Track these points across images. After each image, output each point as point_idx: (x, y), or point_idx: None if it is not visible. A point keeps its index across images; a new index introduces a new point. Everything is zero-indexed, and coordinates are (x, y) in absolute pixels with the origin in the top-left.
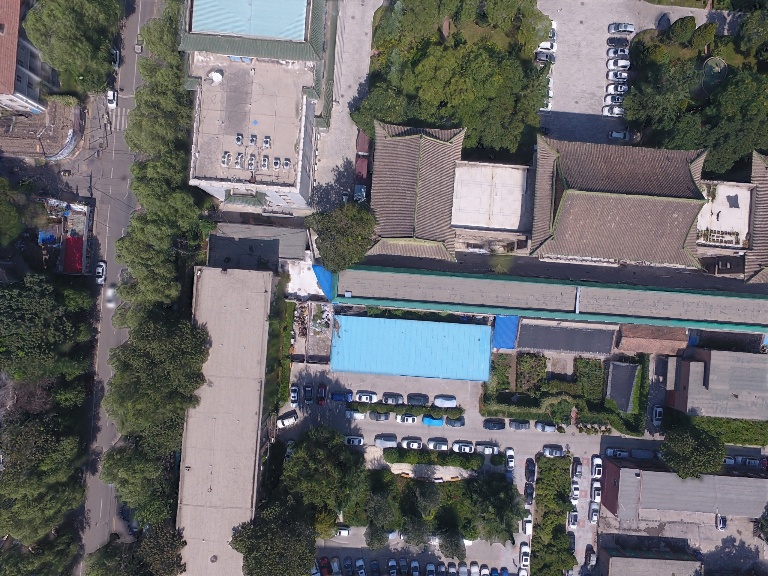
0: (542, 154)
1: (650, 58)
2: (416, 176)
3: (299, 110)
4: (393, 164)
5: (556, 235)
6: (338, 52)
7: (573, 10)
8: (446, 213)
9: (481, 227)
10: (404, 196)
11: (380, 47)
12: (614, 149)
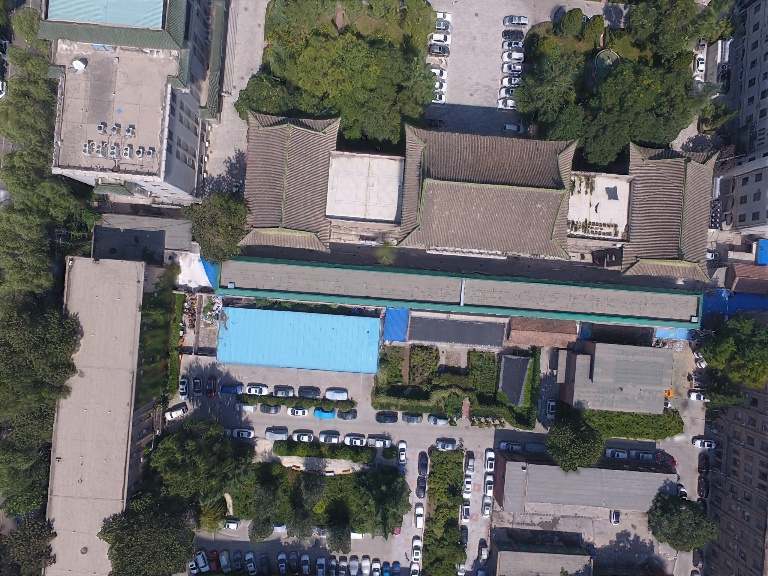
0: (410, 144)
1: (539, 50)
2: (284, 166)
3: (164, 99)
4: (265, 154)
5: (423, 225)
6: (230, 43)
7: (468, 2)
8: (320, 203)
9: (357, 218)
10: (274, 186)
11: (269, 38)
12: (483, 139)
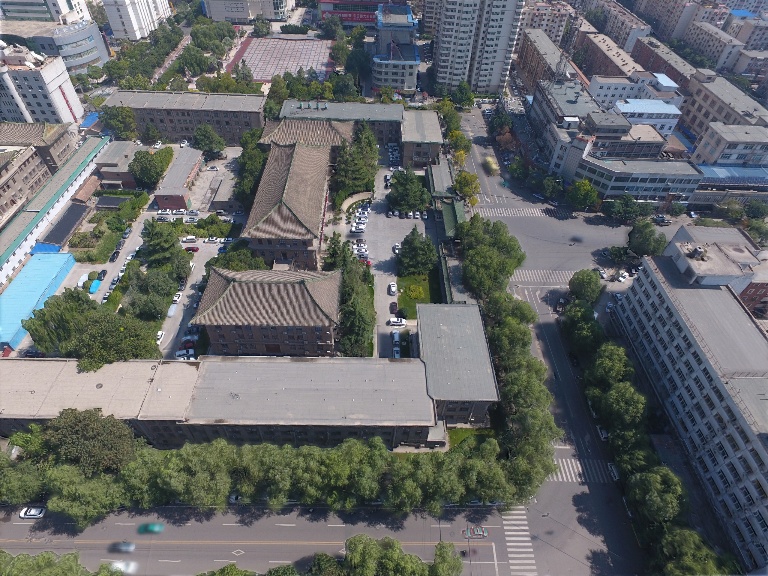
0: None
1: None
2: None
3: None
4: None
5: None
6: None
7: None
8: None
9: None
10: None
11: None
12: None
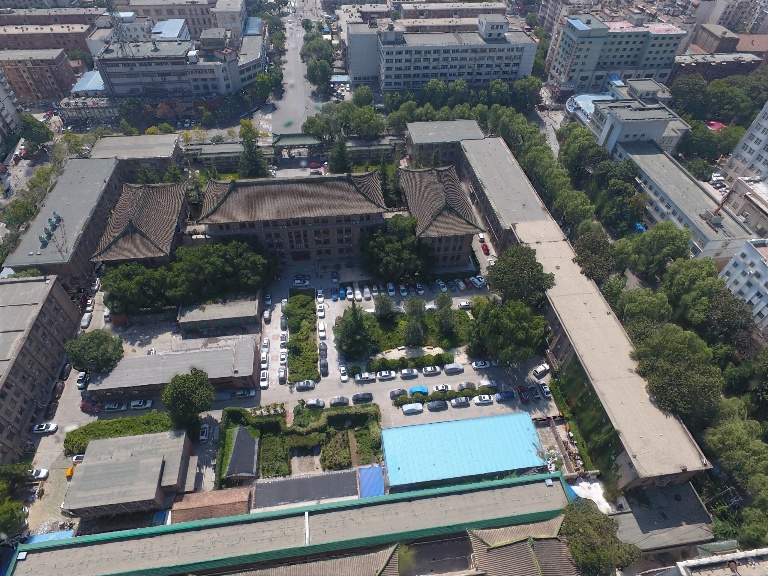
0: None
1: None
2: None
3: None
4: None
5: None
6: None
7: None
8: None
9: None
10: None
11: None
12: None
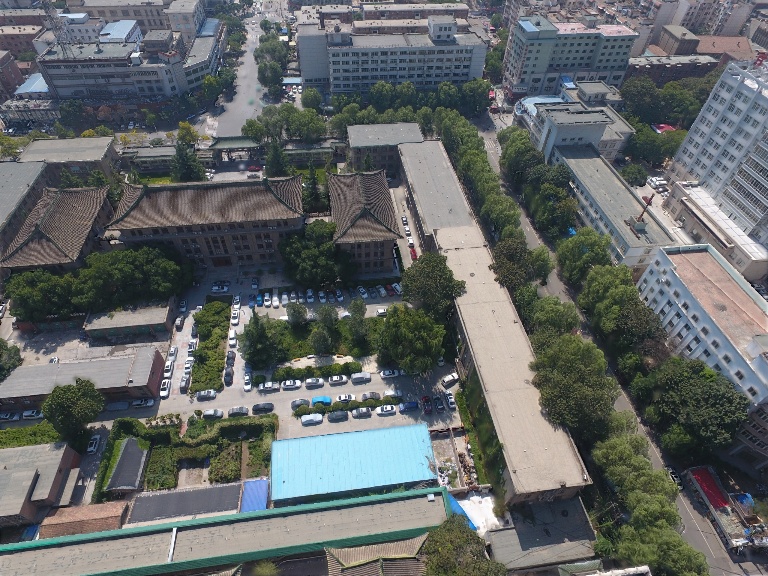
0: None
1: None
2: None
3: None
4: None
5: None
6: None
7: None
8: None
9: None
10: None
11: None
12: None
